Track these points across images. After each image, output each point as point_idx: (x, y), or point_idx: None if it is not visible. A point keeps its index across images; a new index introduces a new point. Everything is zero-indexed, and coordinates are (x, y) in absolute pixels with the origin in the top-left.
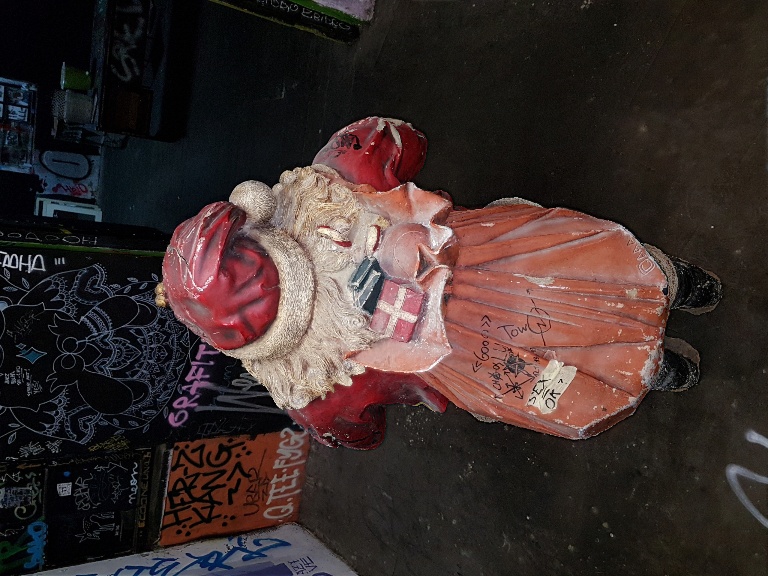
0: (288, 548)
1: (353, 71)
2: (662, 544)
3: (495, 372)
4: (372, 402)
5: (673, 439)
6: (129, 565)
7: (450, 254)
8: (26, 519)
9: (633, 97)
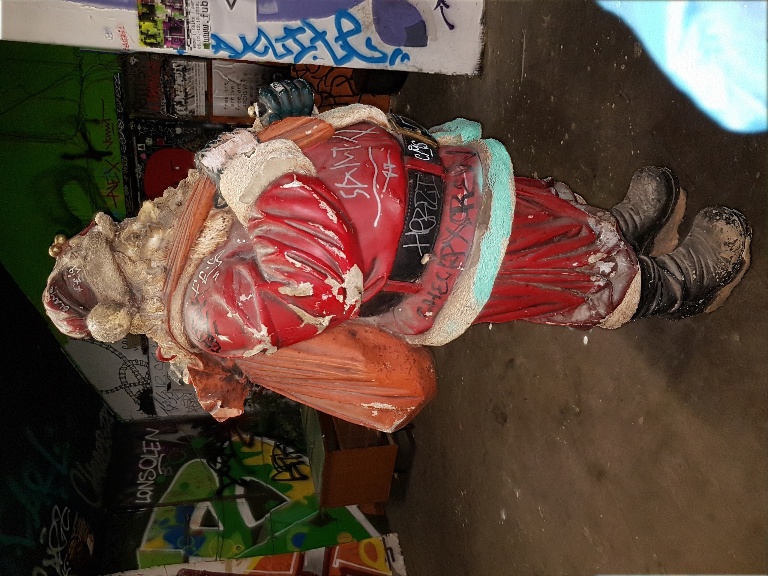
0: None
1: None
2: None
3: None
4: None
5: None
6: None
7: None
8: None
9: None
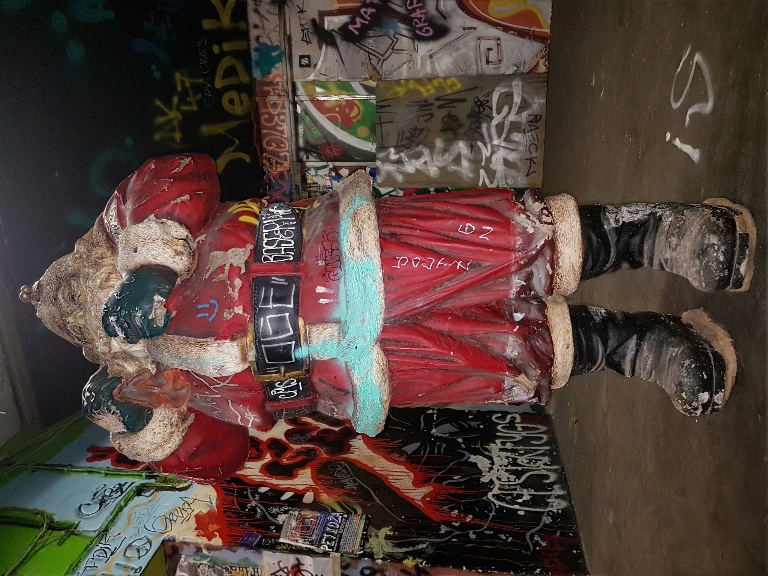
0: None
1: None
2: None
3: None
4: None
5: (744, 119)
6: None
7: None
8: None
9: None
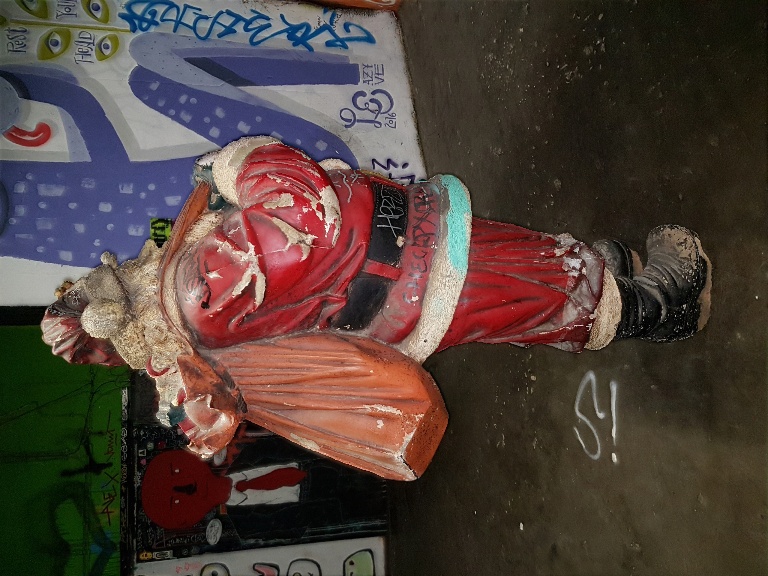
0: (371, 46)
1: None
2: None
3: None
4: None
5: None
6: (229, 9)
7: None
8: None
9: None
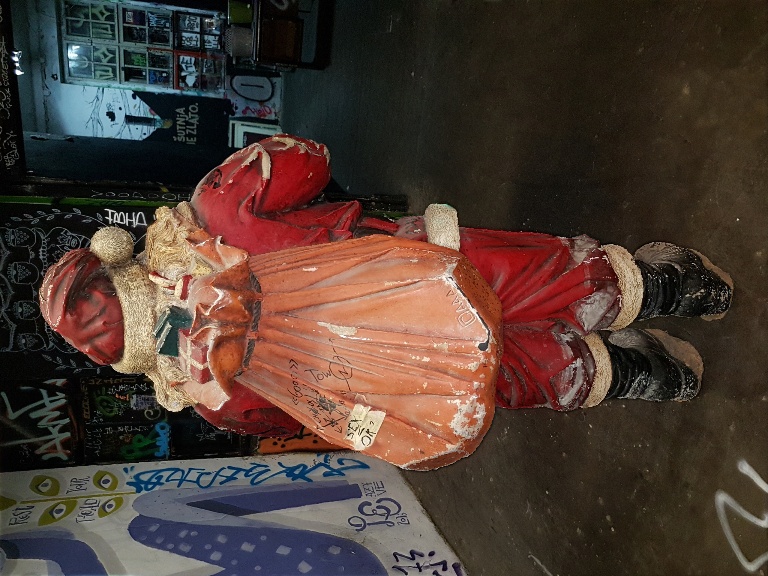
0: (366, 471)
1: (435, 9)
2: (652, 551)
3: (312, 407)
4: (250, 408)
5: (674, 449)
6: (231, 466)
7: (230, 312)
8: (153, 420)
9: (680, 50)
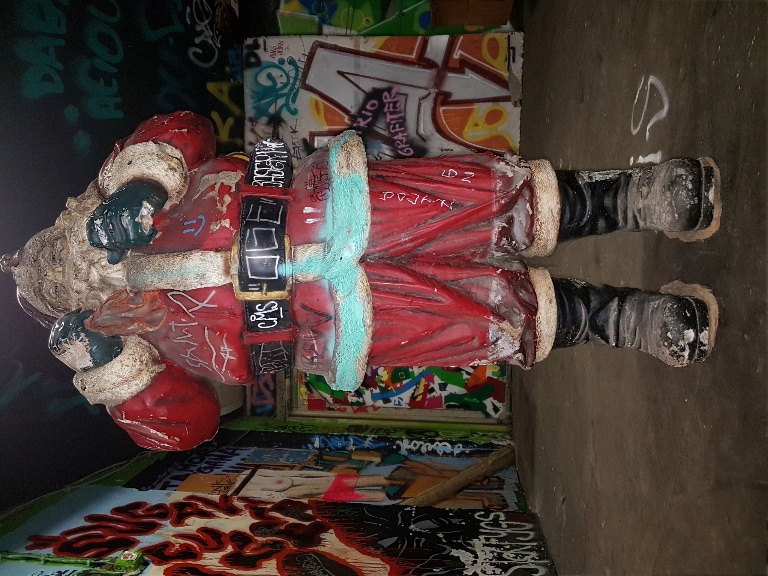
0: None
1: None
2: None
3: None
4: None
5: (696, 98)
6: None
7: None
8: None
9: None
